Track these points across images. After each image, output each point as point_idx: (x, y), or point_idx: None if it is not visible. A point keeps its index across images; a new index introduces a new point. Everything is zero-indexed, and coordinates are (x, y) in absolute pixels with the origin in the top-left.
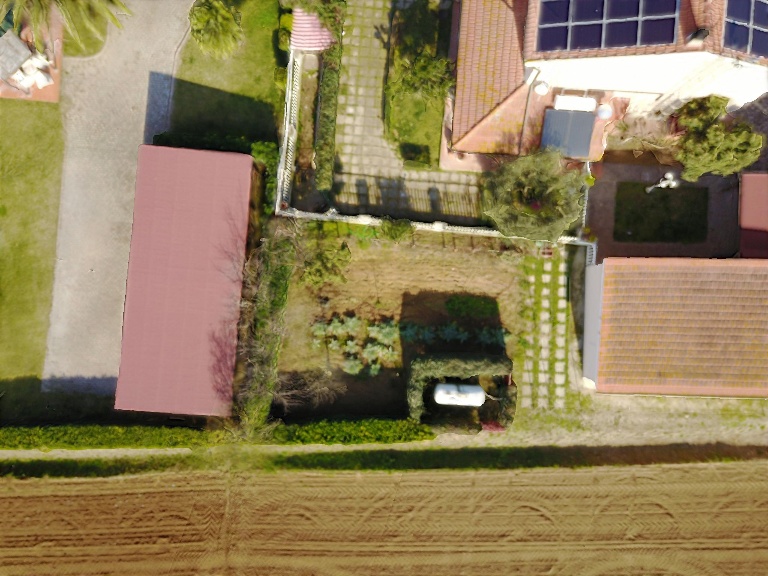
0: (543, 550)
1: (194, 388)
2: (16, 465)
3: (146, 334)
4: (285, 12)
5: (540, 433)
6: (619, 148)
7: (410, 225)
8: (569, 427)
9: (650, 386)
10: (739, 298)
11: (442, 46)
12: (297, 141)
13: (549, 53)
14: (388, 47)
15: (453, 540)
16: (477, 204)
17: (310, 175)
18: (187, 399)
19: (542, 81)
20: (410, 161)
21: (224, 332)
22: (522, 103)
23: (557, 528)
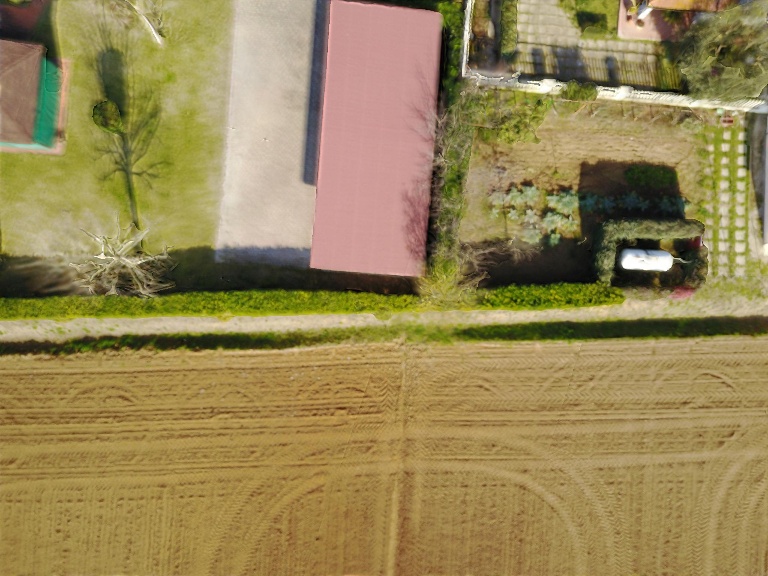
0: (725, 416)
1: (388, 248)
2: (187, 339)
3: (340, 192)
4: None
5: (720, 301)
6: None
7: (596, 90)
8: (749, 295)
9: None
10: None
11: None
12: (473, 9)
13: None
14: None
15: (634, 408)
16: (656, 73)
17: (486, 44)
18: (381, 259)
19: None
20: (592, 27)
21: (417, 192)
22: None
23: (738, 394)
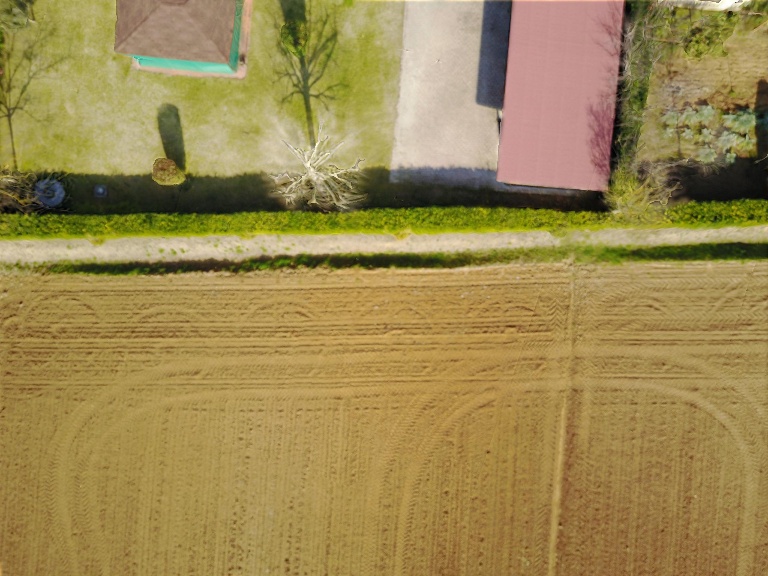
0: None
1: (572, 162)
2: (360, 258)
3: (526, 107)
4: None
5: None
6: None
7: None
8: None
9: None
10: None
11: None
12: None
13: None
14: None
15: None
16: None
17: None
18: (566, 173)
19: None
20: None
21: (601, 106)
22: None
23: None
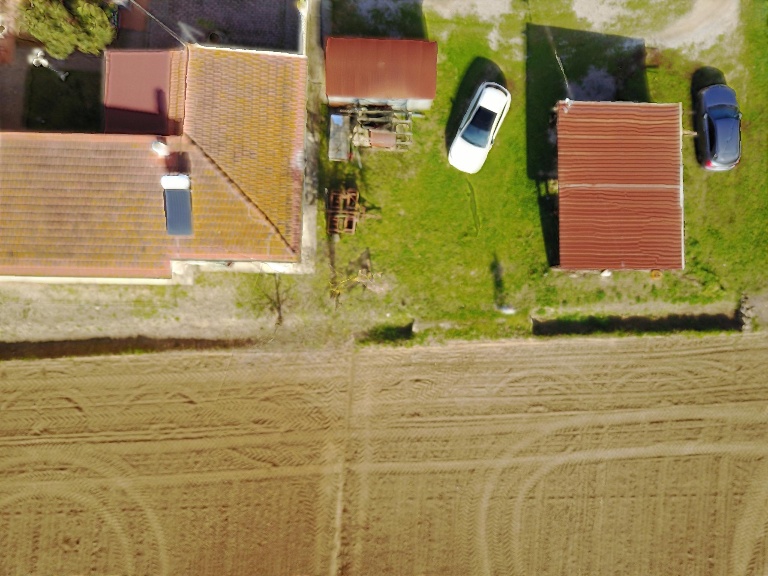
0: None
1: None
2: None
3: None
4: None
5: None
6: None
7: None
8: None
9: (3, 267)
10: (86, 174)
11: None
12: None
13: None
14: None
15: None
16: None
17: None
18: None
19: None
20: None
21: None
22: None
23: None
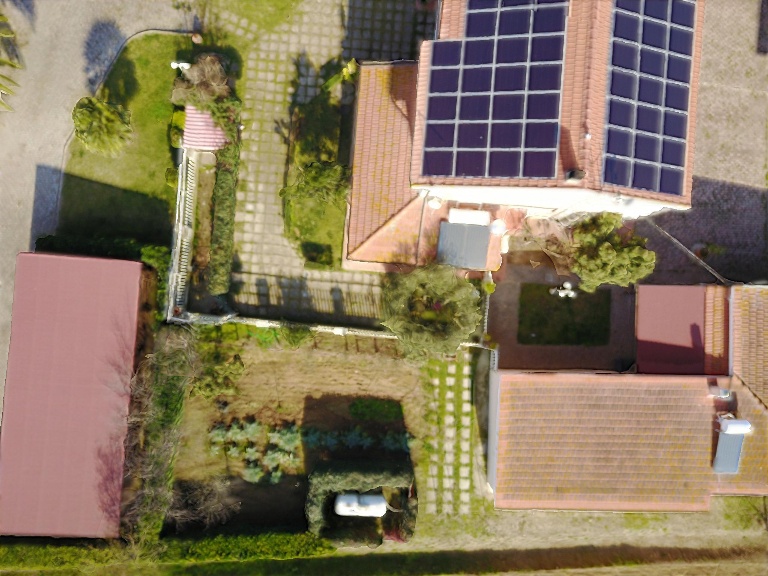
0: None
1: (78, 509)
2: None
3: (25, 454)
4: (177, 110)
5: (445, 539)
6: (523, 249)
7: (309, 331)
8: (473, 533)
9: (547, 501)
10: (634, 413)
11: (344, 142)
12: (194, 240)
13: (435, 178)
14: (289, 142)
15: None
16: (380, 305)
17: (208, 275)
18: (70, 521)
19: (435, 196)
20: (310, 263)
21: (110, 449)
22: (417, 214)
23: None
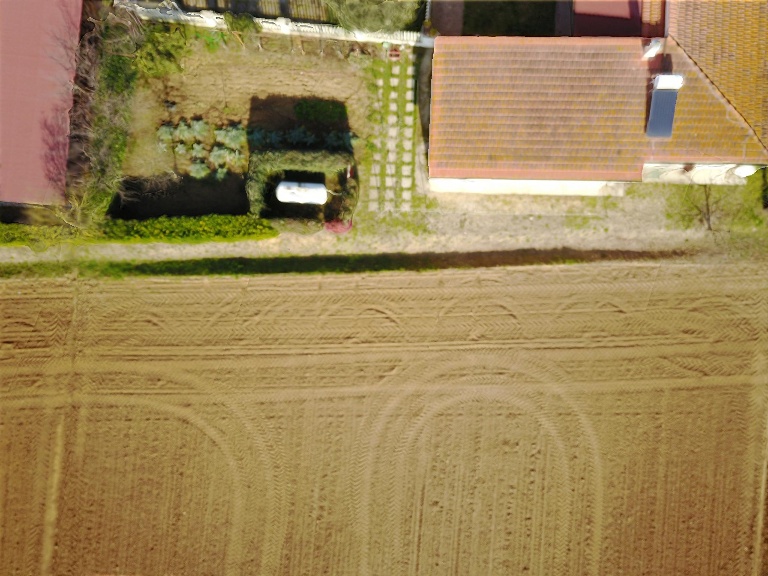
0: (387, 351)
1: (25, 176)
2: None
3: None
4: None
5: (387, 237)
6: None
7: (253, 21)
8: (415, 230)
9: (481, 170)
10: (568, 78)
11: None
12: None
13: None
14: None
15: (299, 343)
16: (326, 7)
17: None
18: (18, 187)
19: None
20: None
21: (56, 120)
22: None
23: (402, 330)
